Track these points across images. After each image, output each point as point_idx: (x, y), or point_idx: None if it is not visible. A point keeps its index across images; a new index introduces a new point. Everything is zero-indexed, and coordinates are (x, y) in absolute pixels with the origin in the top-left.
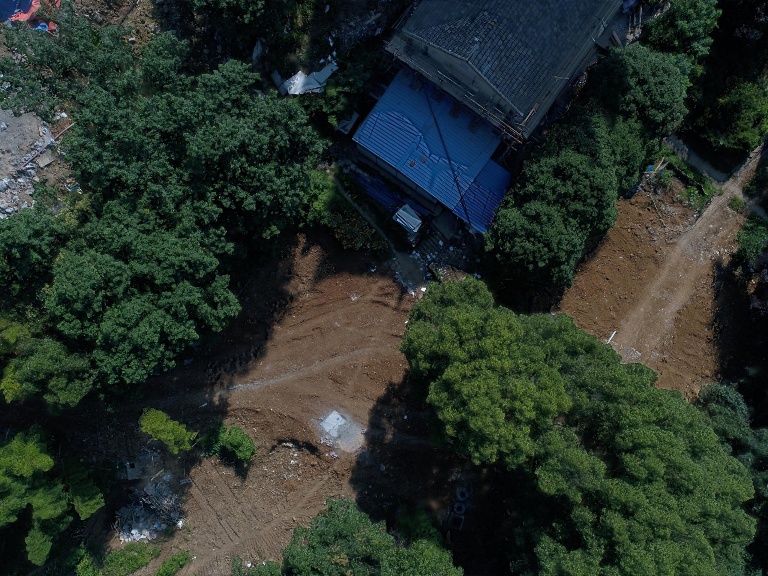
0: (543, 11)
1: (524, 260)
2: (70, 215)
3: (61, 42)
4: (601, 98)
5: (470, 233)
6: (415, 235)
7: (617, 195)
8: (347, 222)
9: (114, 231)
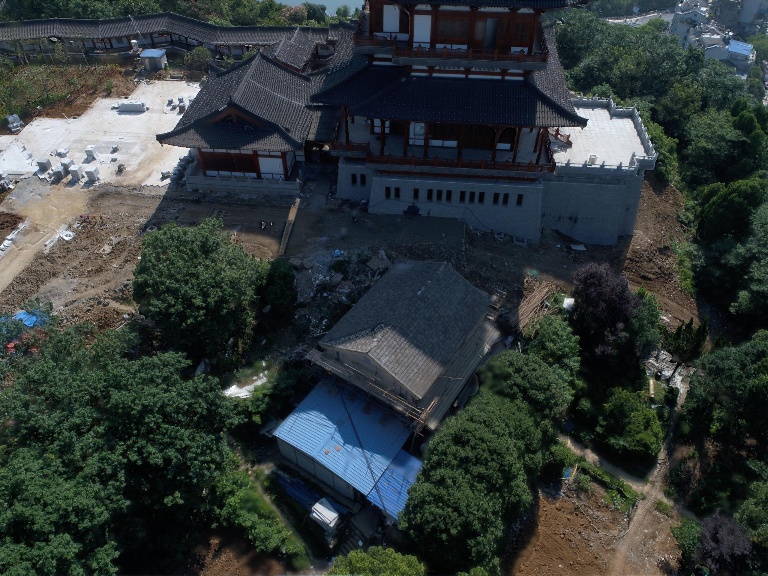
0: (429, 325)
1: (436, 530)
2: None
3: (33, 328)
4: (489, 388)
5: (388, 525)
6: (333, 534)
7: (526, 475)
8: (263, 523)
9: (11, 469)
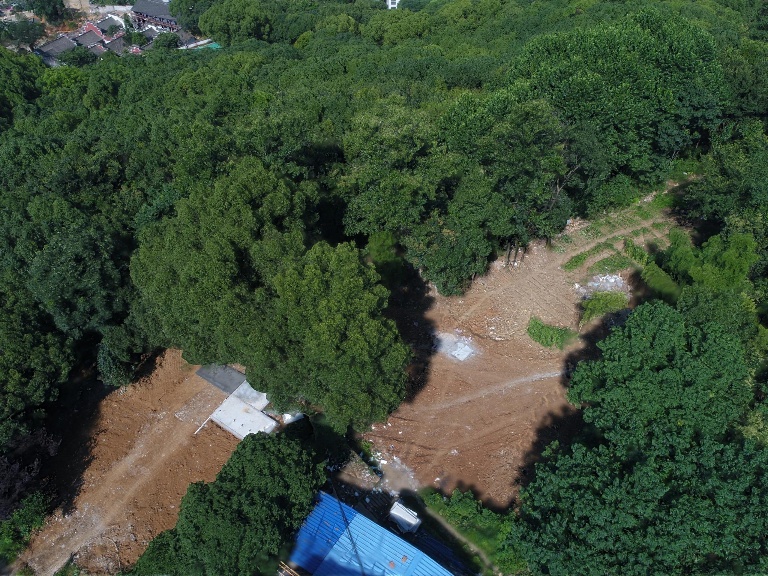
0: None
1: None
2: (759, 425)
3: None
4: None
5: None
6: None
7: None
8: None
9: None
